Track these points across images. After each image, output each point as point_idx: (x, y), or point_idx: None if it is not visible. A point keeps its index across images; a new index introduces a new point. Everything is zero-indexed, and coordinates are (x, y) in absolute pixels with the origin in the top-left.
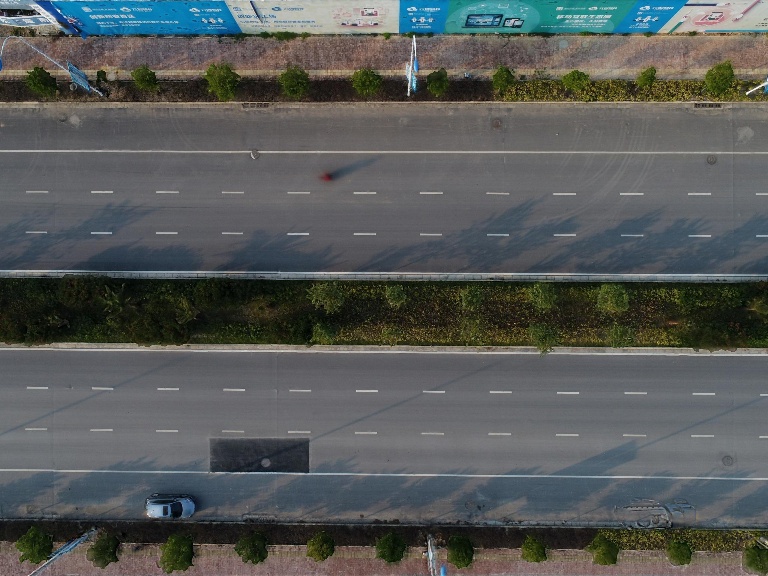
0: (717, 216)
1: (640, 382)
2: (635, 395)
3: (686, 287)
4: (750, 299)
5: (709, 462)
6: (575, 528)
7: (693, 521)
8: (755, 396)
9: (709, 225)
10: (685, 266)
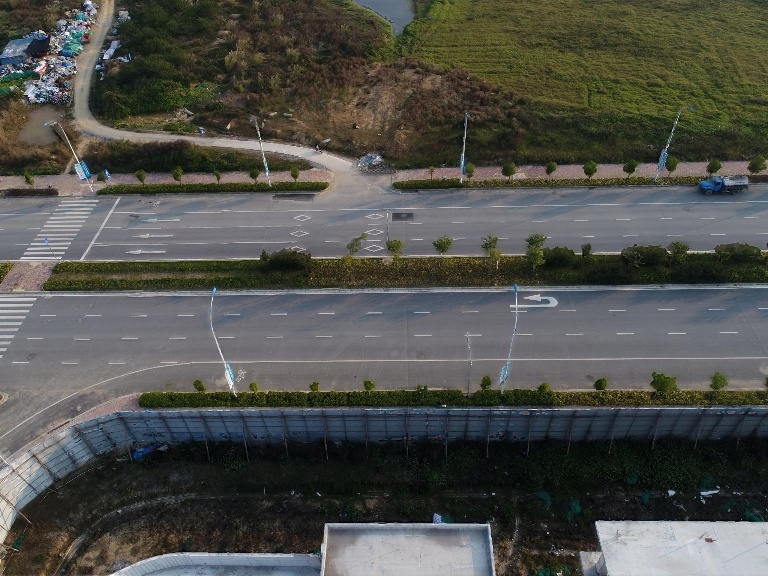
0: (760, 319)
1: (763, 238)
2: (762, 233)
3: (762, 280)
4: (724, 267)
5: (697, 209)
6: (763, 183)
7: (703, 182)
8: (684, 234)
9: (763, 314)
10: (767, 292)
